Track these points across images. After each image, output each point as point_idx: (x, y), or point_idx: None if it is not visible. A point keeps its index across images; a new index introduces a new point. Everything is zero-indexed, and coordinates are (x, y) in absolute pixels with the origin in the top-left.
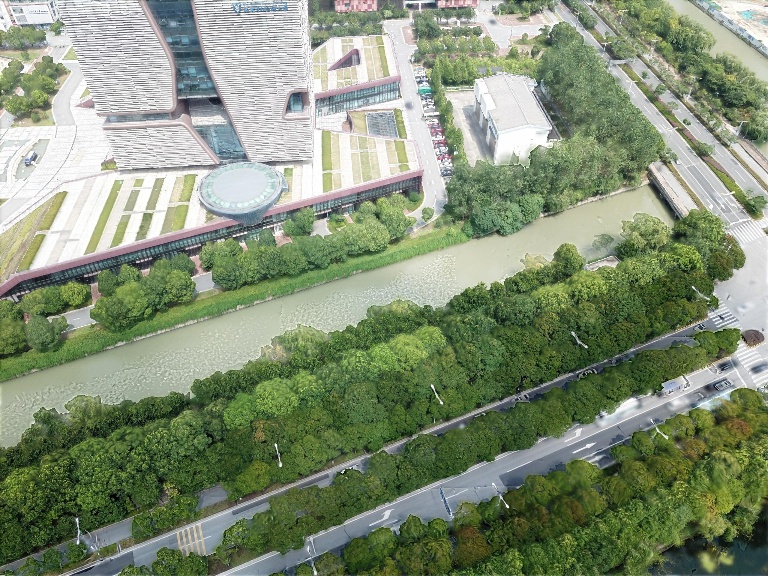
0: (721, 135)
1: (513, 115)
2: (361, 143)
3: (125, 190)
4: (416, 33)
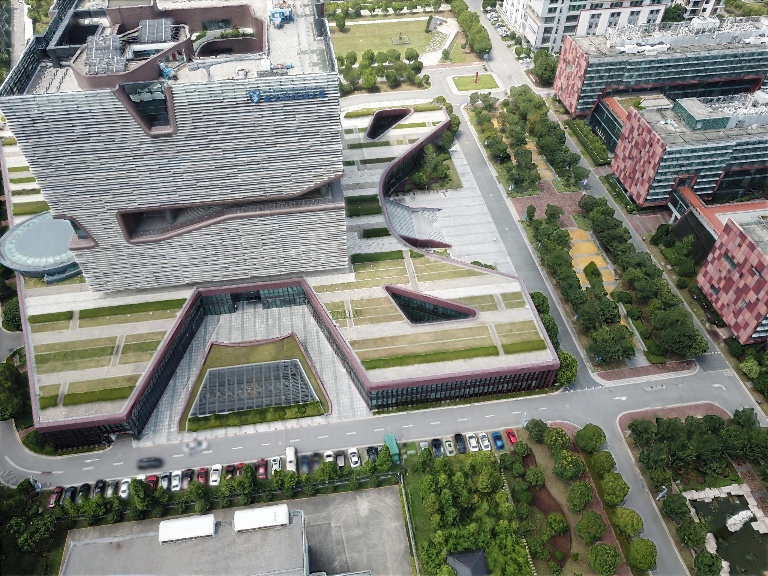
0: None
1: (113, 575)
2: (138, 345)
3: None
4: None
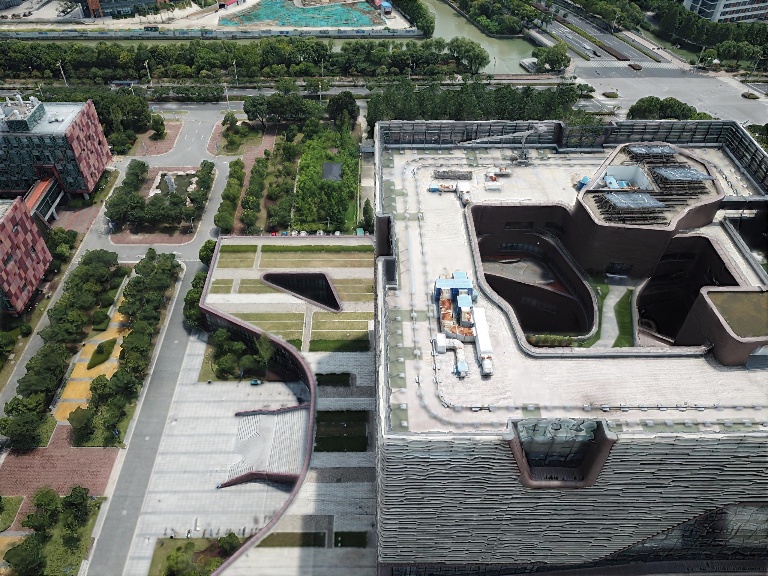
0: (479, 81)
1: None
2: None
3: None
4: (150, 230)
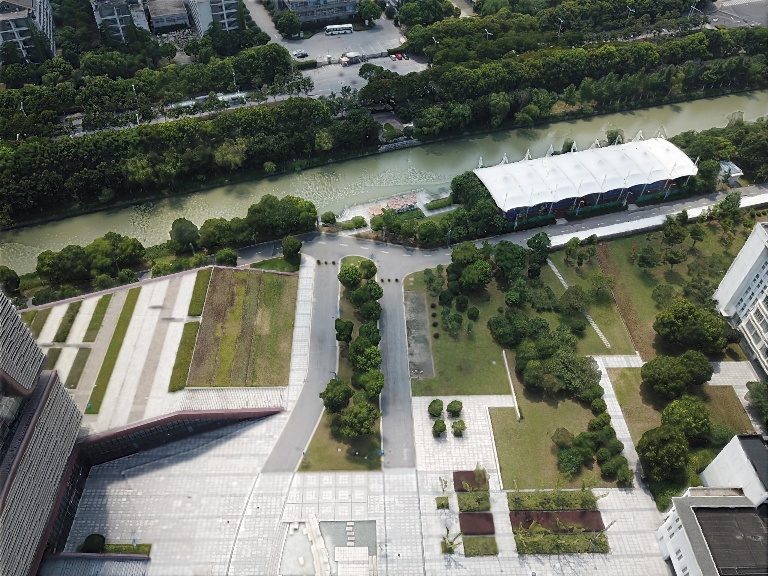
0: None
1: None
2: None
3: (85, 390)
4: None
